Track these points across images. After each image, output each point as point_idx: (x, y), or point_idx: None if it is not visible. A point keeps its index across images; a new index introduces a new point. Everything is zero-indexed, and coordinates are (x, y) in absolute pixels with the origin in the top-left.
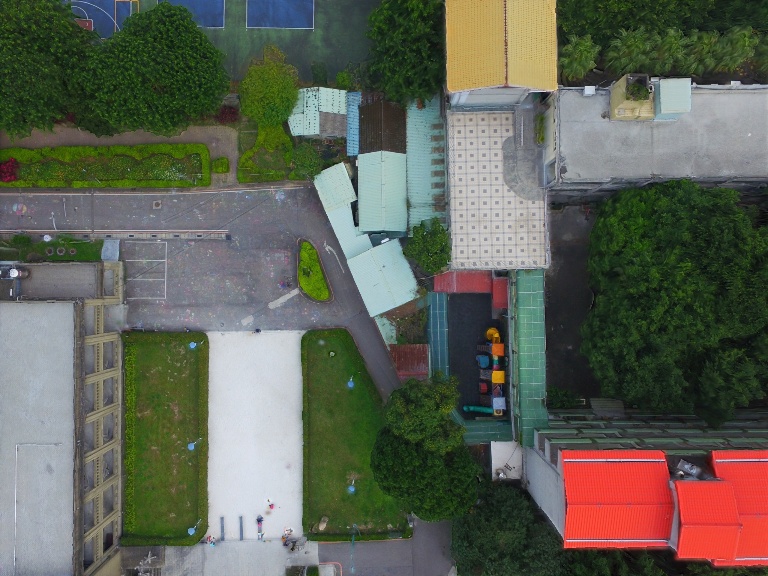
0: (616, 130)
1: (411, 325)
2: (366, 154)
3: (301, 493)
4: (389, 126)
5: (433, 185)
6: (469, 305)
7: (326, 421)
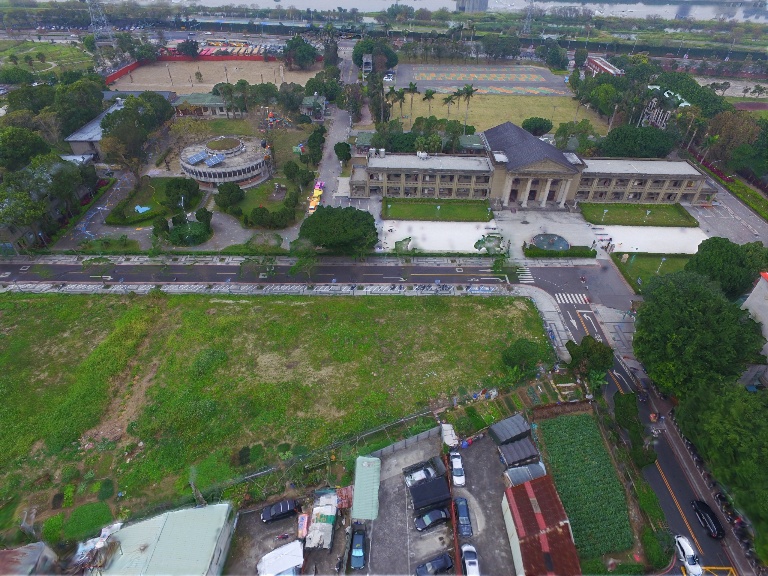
0: None
1: None
2: None
3: None
4: None
5: None
6: None
7: (683, 264)
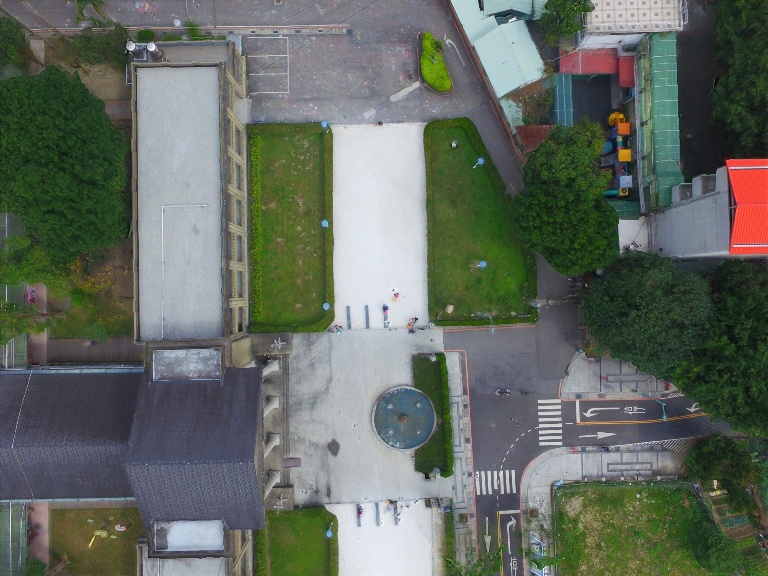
0: None
1: (537, 107)
2: None
3: (425, 282)
4: None
5: None
6: (589, 95)
7: (449, 211)
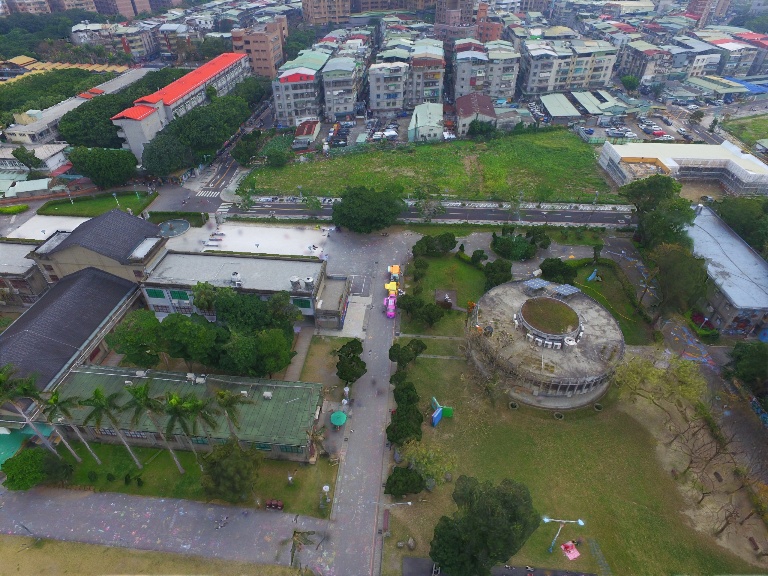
0: (33, 124)
1: None
2: None
3: None
4: None
5: None
6: None
7: None
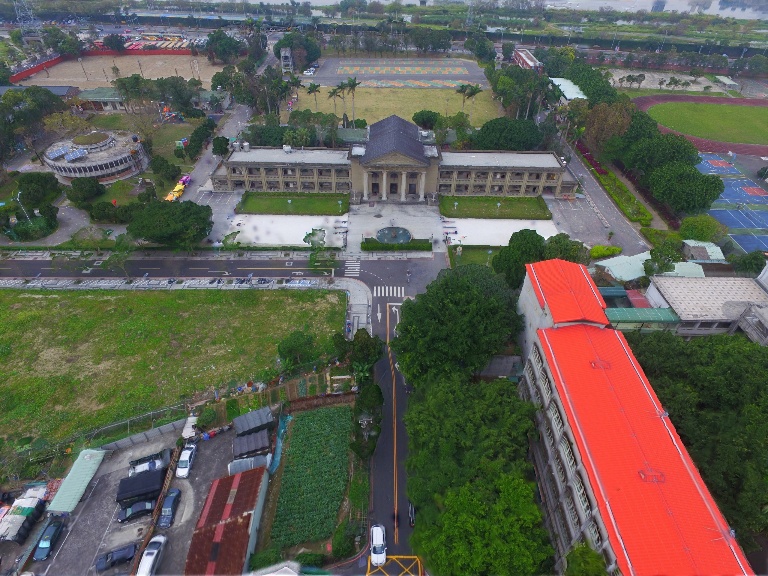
0: None
1: (597, 280)
2: (693, 263)
3: None
4: (719, 270)
5: None
6: None
7: None
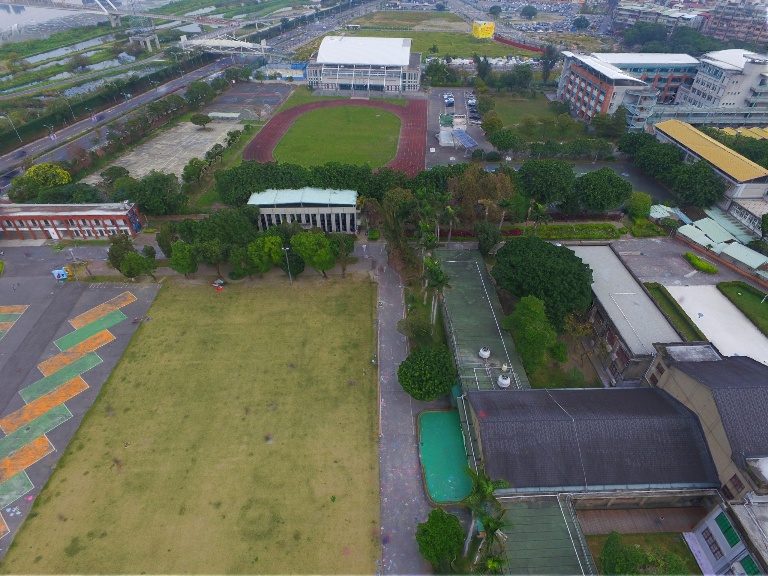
0: None
1: None
2: (698, 221)
3: None
4: None
5: (740, 229)
6: None
7: (765, 322)
